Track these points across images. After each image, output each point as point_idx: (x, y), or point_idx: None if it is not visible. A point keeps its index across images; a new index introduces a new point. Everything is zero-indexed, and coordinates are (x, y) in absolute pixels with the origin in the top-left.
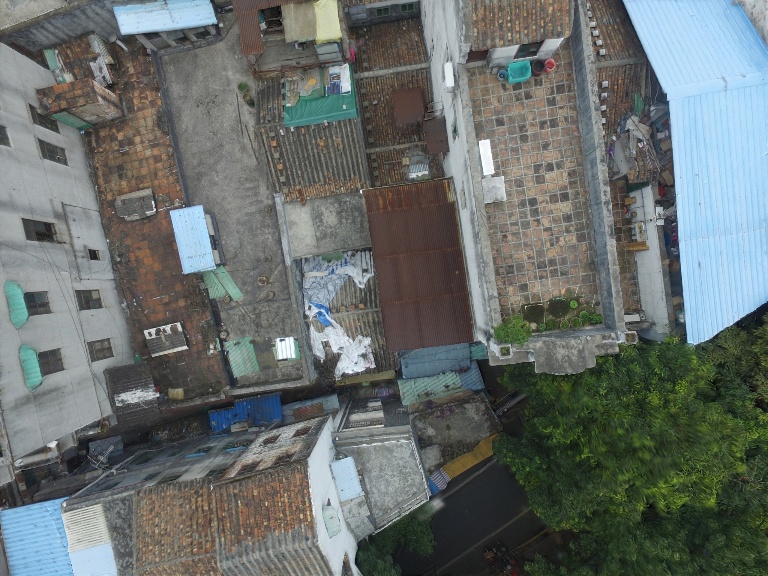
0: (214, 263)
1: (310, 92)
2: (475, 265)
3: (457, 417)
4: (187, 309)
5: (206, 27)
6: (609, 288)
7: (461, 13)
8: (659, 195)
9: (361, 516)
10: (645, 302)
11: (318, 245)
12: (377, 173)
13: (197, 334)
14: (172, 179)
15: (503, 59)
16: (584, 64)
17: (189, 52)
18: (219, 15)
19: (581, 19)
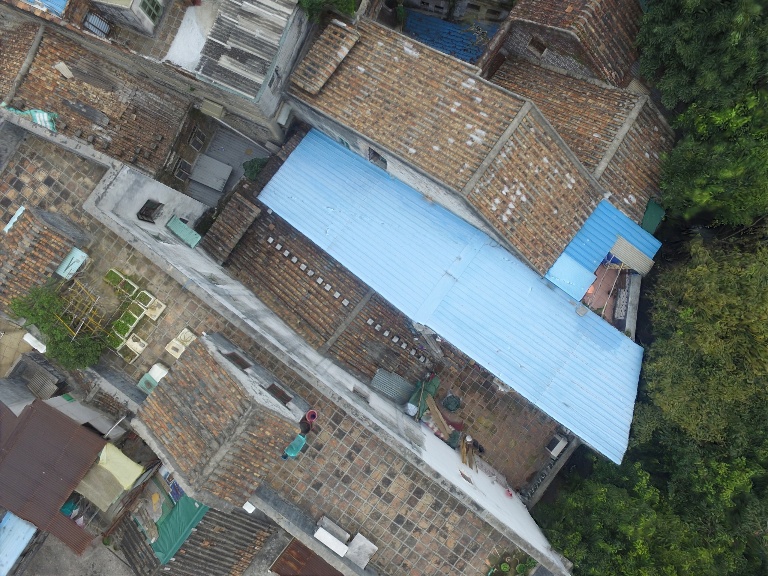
0: None
1: (161, 511)
2: None
3: None
4: None
5: None
6: None
7: None
8: None
9: None
10: None
11: None
12: None
13: None
14: None
15: None
16: None
17: (40, 550)
18: None
19: (300, 375)
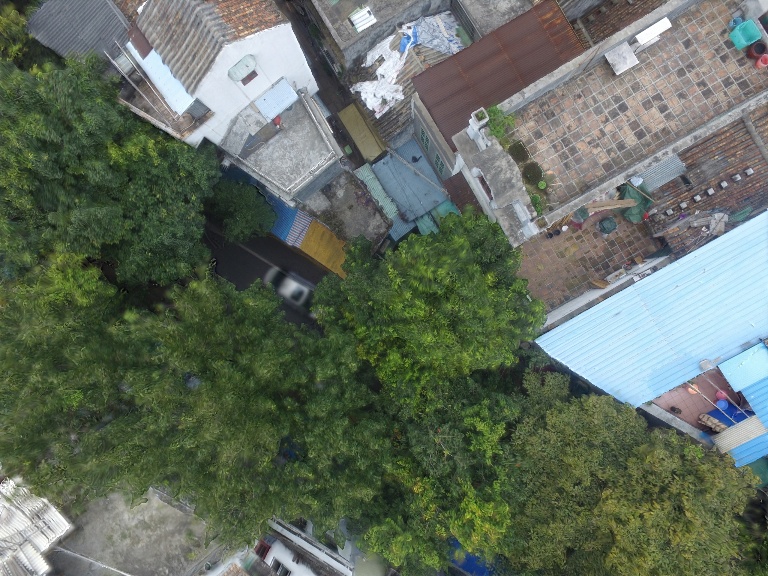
0: None
1: None
2: None
3: (363, 211)
4: None
5: None
6: None
7: None
8: None
9: (248, 128)
10: (549, 315)
11: (473, 3)
12: None
13: None
14: None
15: (755, 7)
16: None
17: None
18: None
19: None
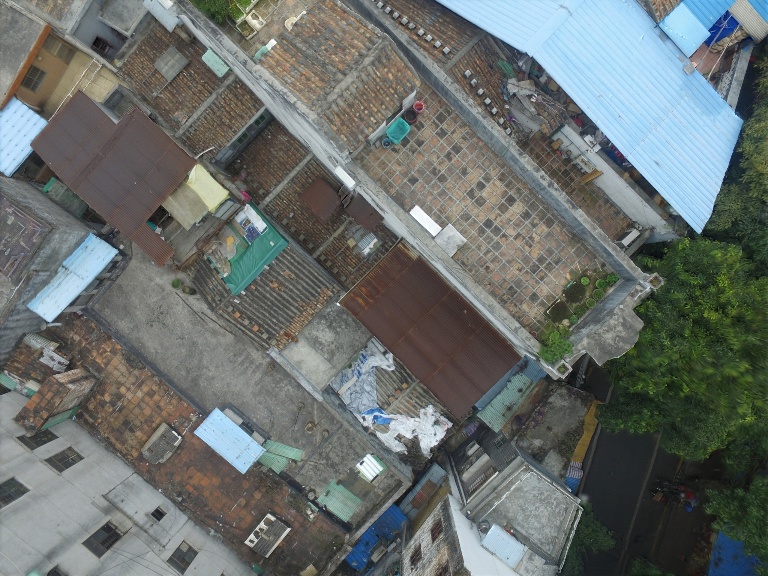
0: (261, 447)
1: (235, 251)
2: (479, 303)
3: (550, 415)
4: (266, 497)
5: (112, 260)
6: (605, 250)
7: (321, 133)
8: (579, 127)
9: (539, 568)
10: (632, 215)
11: (333, 365)
12: (336, 270)
13: (289, 511)
14: (175, 401)
15: (378, 133)
16: (446, 89)
17: (112, 287)
18: (114, 240)
19: (417, 56)
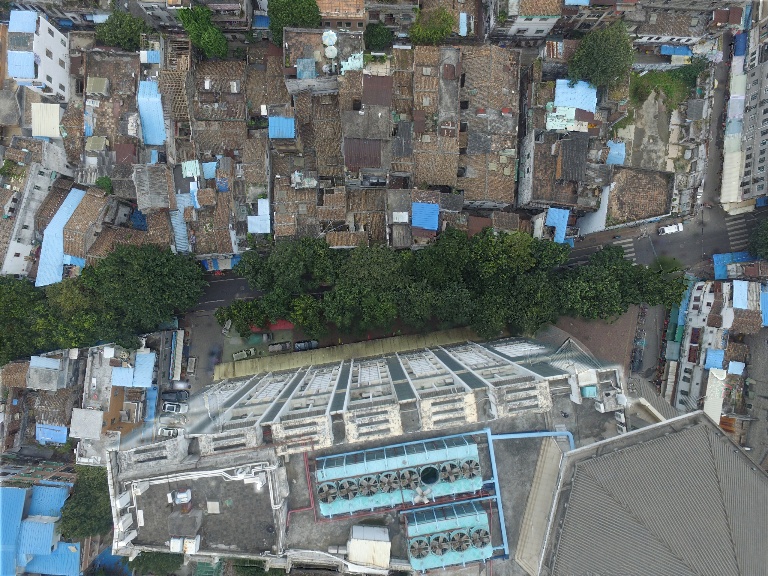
0: None
1: None
2: None
3: None
4: None
5: None
6: None
7: None
8: None
9: None
10: None
11: None
12: None
13: None
14: None
15: None
16: (14, 221)
17: None
18: None
19: (17, 212)
